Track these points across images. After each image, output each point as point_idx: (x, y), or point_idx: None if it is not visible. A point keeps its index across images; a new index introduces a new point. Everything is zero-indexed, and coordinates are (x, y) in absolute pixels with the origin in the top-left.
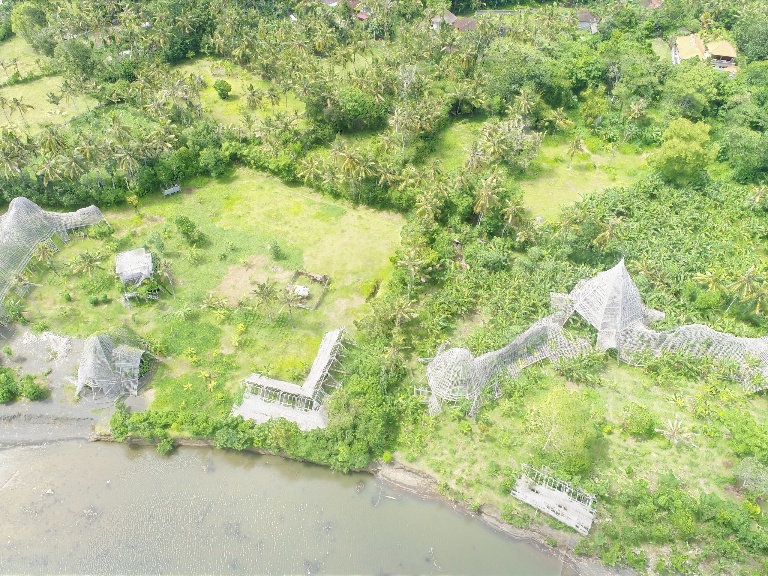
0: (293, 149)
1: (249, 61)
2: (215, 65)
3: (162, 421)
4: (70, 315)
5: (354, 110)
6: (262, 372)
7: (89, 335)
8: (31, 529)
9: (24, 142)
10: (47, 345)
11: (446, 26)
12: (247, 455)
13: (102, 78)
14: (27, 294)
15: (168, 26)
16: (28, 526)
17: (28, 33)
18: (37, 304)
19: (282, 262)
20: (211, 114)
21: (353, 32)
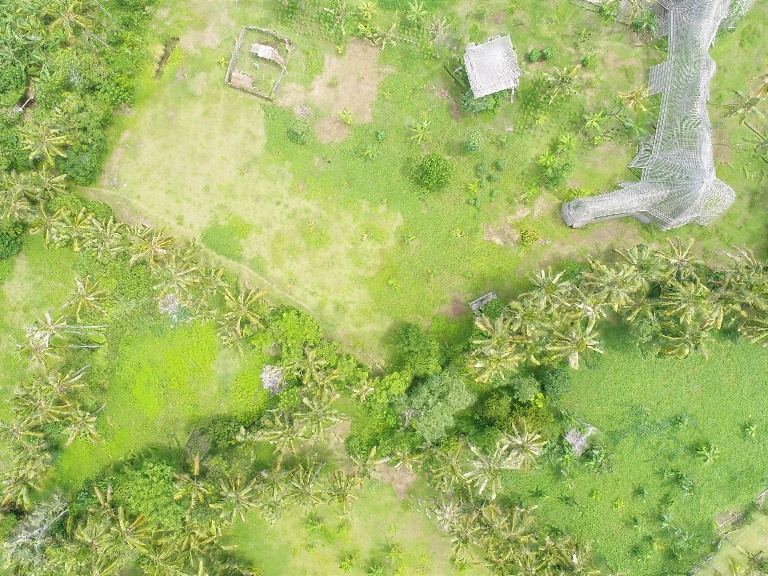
0: None
1: None
2: None
3: None
4: (575, 36)
5: None
6: None
7: None
8: None
9: None
10: None
11: None
12: None
13: None
14: (647, 78)
15: None
16: None
17: None
18: (627, 58)
19: None
20: None
21: None
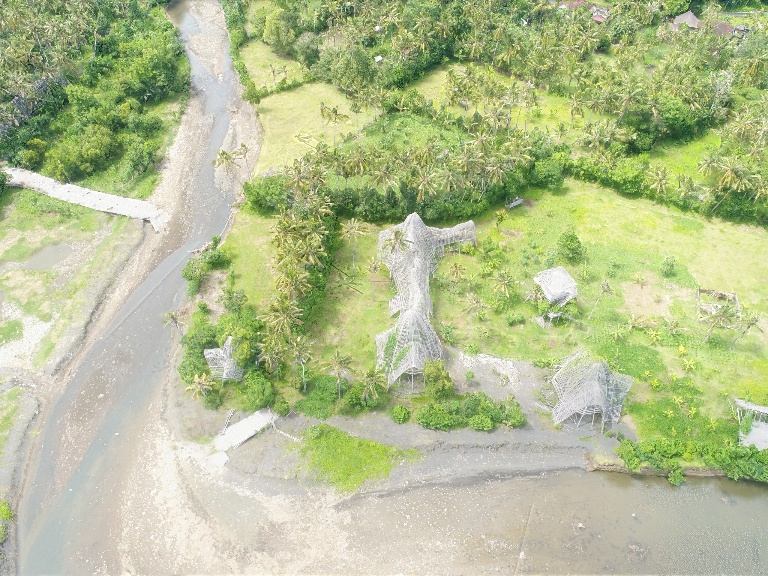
0: (642, 160)
1: (510, 66)
2: None
3: (673, 451)
4: (491, 336)
5: (674, 118)
6: (745, 398)
7: (527, 357)
8: (586, 566)
9: None
10: (493, 368)
11: None
12: (760, 486)
13: (382, 85)
14: (434, 313)
15: None
16: (581, 563)
17: (281, 39)
18: (451, 324)
19: (674, 279)
20: None
21: (609, 36)
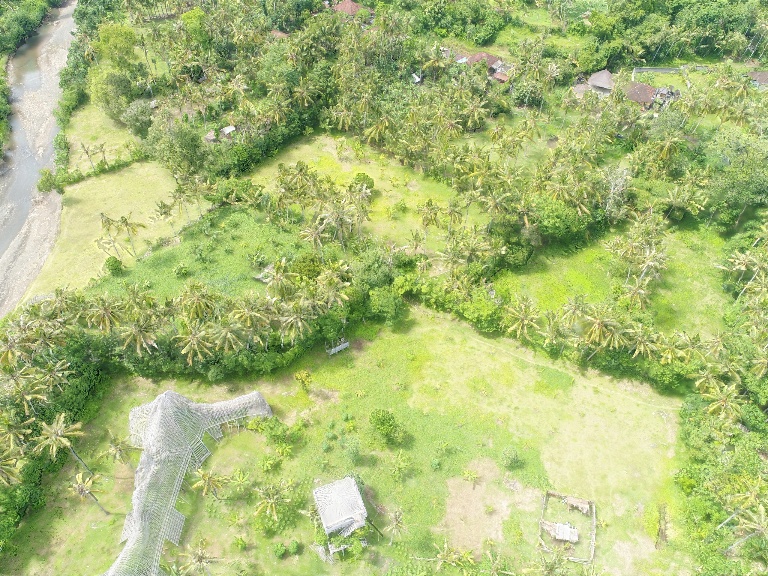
0: (499, 294)
1: (383, 141)
2: (338, 144)
3: None
4: None
5: (554, 227)
6: None
7: None
8: None
9: (128, 265)
10: None
11: (622, 97)
12: None
13: (214, 172)
14: (182, 536)
15: (284, 98)
16: None
17: (111, 106)
18: None
19: (518, 473)
20: (353, 219)
21: (505, 103)
